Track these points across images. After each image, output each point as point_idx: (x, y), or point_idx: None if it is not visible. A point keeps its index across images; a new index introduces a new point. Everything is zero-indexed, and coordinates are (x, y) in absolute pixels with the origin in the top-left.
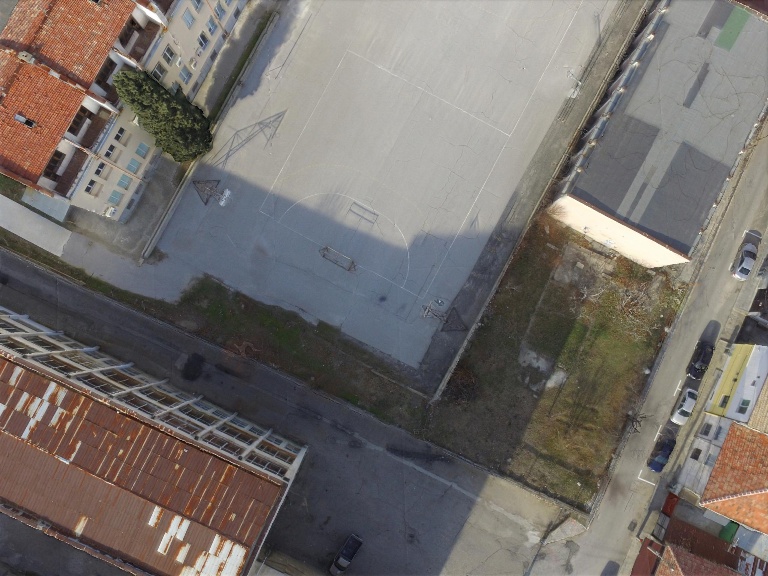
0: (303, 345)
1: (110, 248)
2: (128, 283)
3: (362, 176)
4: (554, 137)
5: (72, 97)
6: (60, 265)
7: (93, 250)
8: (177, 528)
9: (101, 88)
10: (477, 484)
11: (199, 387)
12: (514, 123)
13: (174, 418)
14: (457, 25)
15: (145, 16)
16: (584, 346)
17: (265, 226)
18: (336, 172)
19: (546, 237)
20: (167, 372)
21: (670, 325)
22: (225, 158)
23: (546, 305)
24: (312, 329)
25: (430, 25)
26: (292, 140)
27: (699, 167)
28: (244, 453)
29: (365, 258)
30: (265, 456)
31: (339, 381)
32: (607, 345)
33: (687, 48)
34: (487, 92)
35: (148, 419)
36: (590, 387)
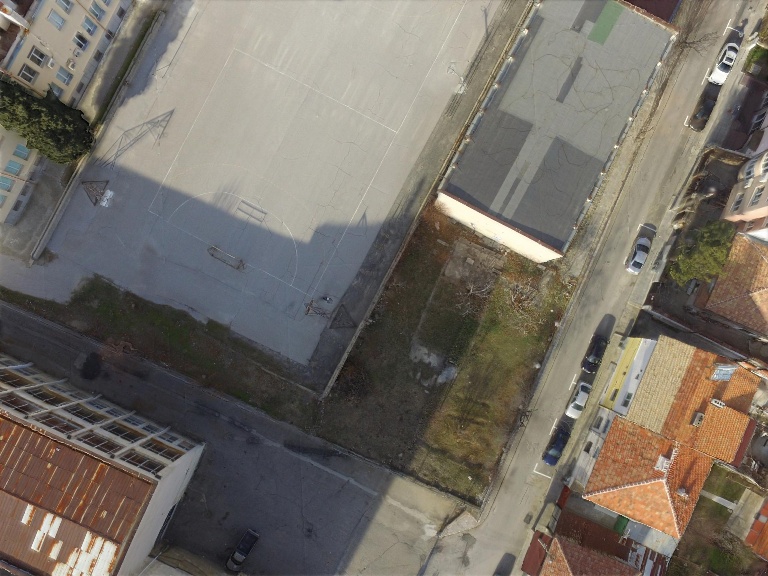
0: (194, 344)
1: (0, 250)
2: (18, 284)
3: (250, 175)
4: (441, 133)
5: None
6: None
7: None
8: (49, 526)
9: None
10: (374, 479)
11: (98, 386)
12: (401, 119)
13: (54, 417)
14: (343, 21)
15: (5, 18)
16: (475, 341)
17: (154, 226)
18: (224, 171)
19: (436, 233)
20: (66, 372)
21: (560, 319)
22: (113, 158)
23: (437, 301)
24: (202, 328)
25: (316, 22)
26: (180, 139)
27: (573, 162)
28: (119, 451)
29: (254, 256)
30: (145, 454)
31: (230, 379)
32: (498, 340)
33: (561, 42)
34: (374, 89)
35: (20, 419)
36: (481, 382)
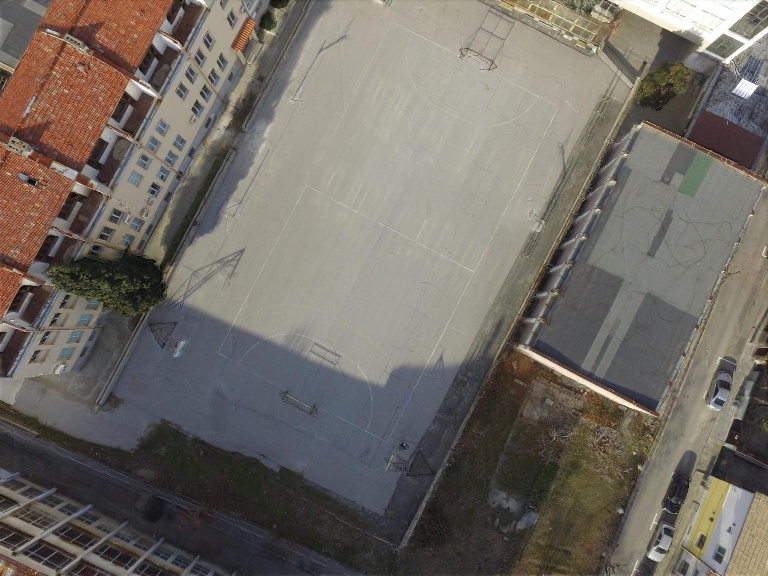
0: (264, 492)
1: (64, 395)
2: (83, 432)
3: (323, 316)
4: (519, 272)
5: (9, 281)
6: (12, 414)
7: (46, 398)
8: None
9: (43, 262)
10: None
11: (160, 529)
12: (478, 258)
13: None
14: (418, 159)
15: None
16: (555, 485)
17: (224, 369)
18: (296, 312)
19: (514, 373)
20: (127, 514)
21: (643, 463)
22: (182, 299)
23: (515, 443)
24: (273, 476)
25: (390, 159)
26: (250, 279)
27: (665, 318)
28: None
29: (327, 401)
30: None
31: (302, 528)
32: (579, 484)
33: (650, 194)
34: (450, 227)
35: None
36: (562, 528)
